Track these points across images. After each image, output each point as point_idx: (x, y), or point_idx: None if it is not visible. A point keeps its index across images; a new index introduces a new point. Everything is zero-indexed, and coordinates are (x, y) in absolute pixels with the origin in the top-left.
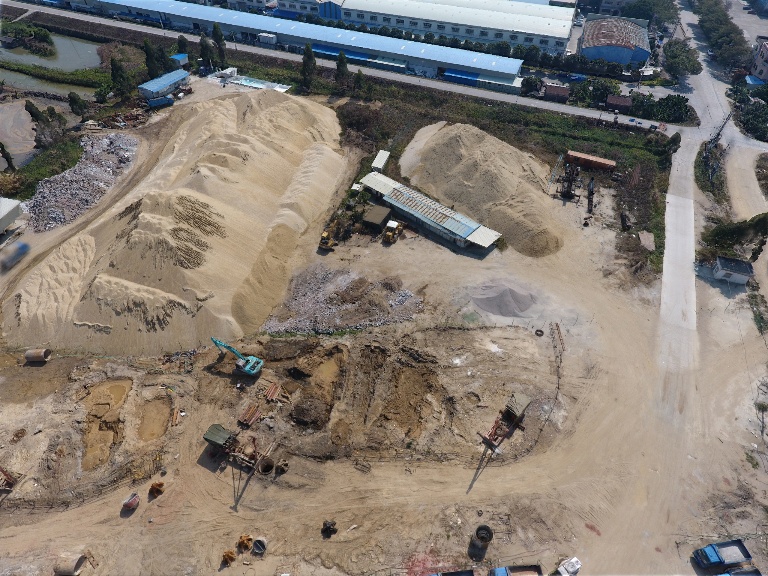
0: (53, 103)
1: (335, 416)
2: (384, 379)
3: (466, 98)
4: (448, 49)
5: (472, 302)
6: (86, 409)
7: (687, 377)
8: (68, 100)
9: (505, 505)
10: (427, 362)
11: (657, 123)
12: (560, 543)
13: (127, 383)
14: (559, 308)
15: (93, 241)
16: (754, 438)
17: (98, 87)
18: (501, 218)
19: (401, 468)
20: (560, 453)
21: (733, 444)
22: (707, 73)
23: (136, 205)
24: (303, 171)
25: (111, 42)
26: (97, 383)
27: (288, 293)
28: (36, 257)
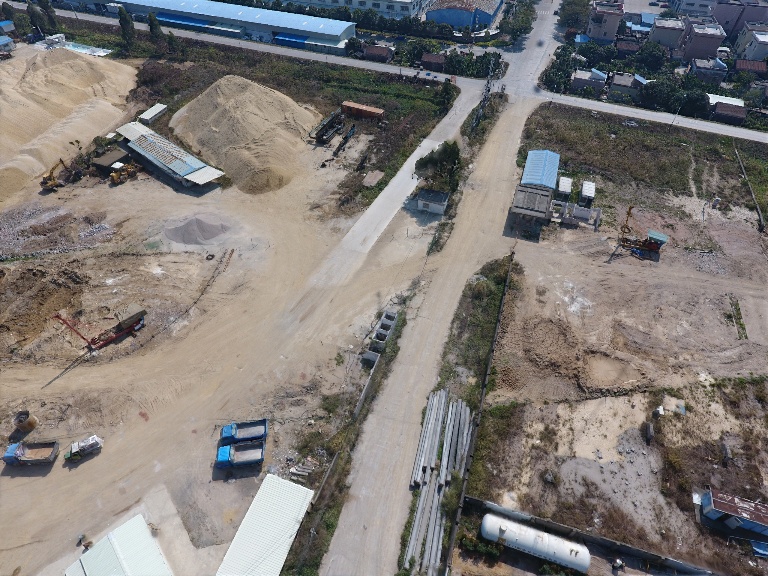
0: None
1: None
2: (25, 296)
3: (281, 58)
4: (285, 14)
5: (163, 232)
6: None
7: (329, 292)
8: None
9: (73, 398)
10: (82, 283)
11: (457, 77)
12: (103, 427)
13: None
14: (245, 236)
15: None
16: (355, 341)
17: None
18: (234, 160)
19: None
20: (158, 355)
21: (331, 346)
22: (550, 35)
23: None
24: (63, 122)
25: None
26: None
27: None
28: None
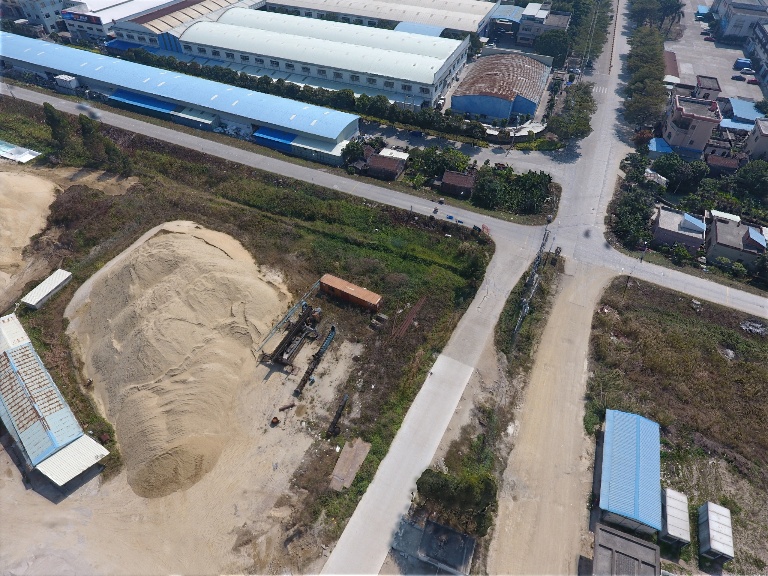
0: None
1: None
2: None
3: (254, 174)
4: (270, 100)
5: None
6: None
7: None
8: None
9: None
10: None
11: (490, 219)
12: None
13: None
14: None
15: None
16: None
17: None
18: (131, 416)
19: None
20: None
21: None
22: (612, 129)
23: None
24: None
25: None
26: None
27: None
28: None
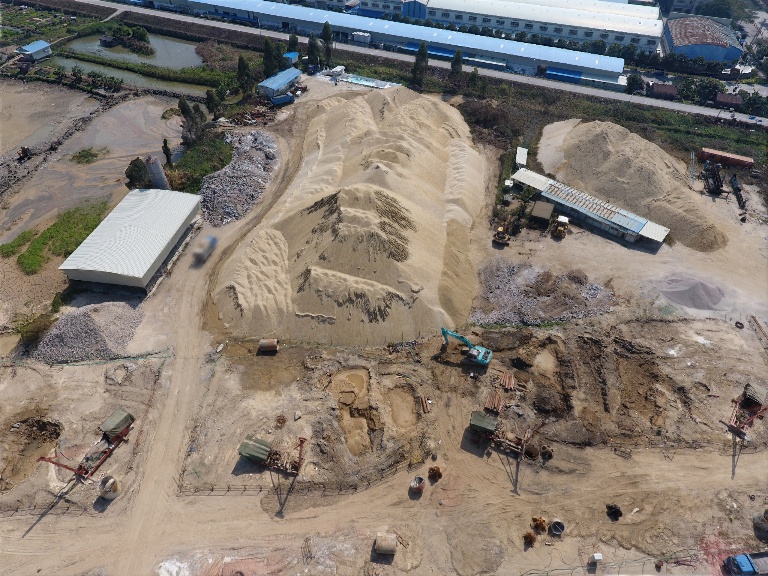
0: (174, 101)
1: (578, 404)
2: (610, 369)
3: (578, 96)
4: (546, 48)
5: (662, 295)
6: (335, 397)
7: None
8: (188, 98)
9: None
10: (642, 353)
11: None
12: None
13: (363, 372)
14: (749, 301)
15: (281, 235)
16: None
17: (210, 85)
18: (663, 214)
19: (659, 454)
20: None
21: None
22: None
23: (328, 200)
24: (454, 167)
25: (207, 41)
26: (335, 372)
27: (481, 286)
28: (225, 250)
